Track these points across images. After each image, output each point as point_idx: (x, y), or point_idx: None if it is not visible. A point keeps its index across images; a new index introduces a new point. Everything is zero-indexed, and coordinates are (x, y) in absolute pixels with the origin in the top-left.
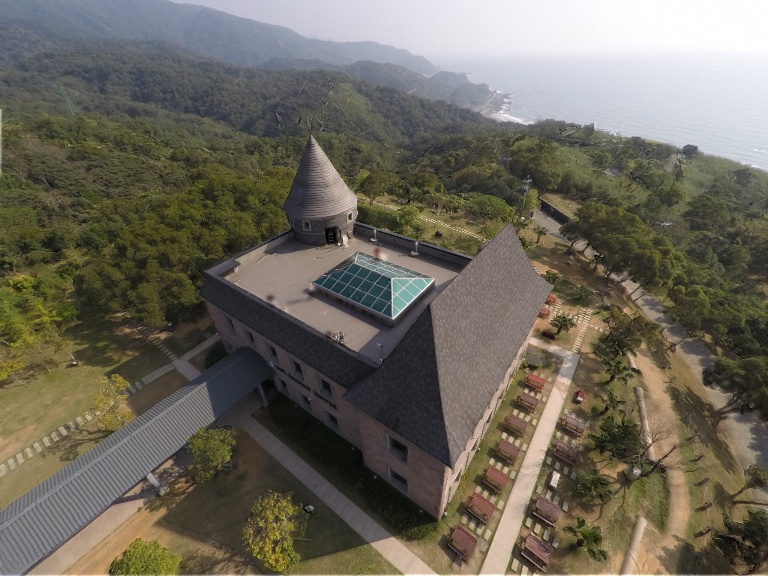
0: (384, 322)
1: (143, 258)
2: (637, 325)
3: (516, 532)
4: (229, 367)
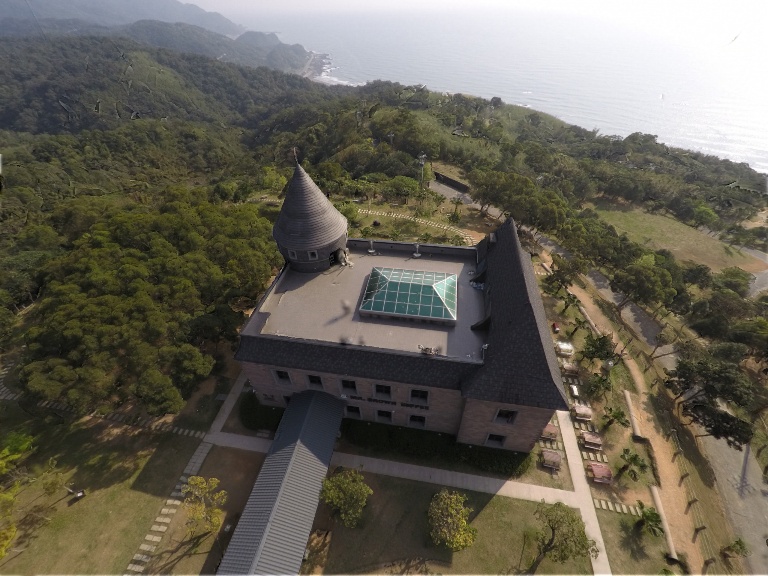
0: (446, 324)
1: (120, 343)
2: (575, 265)
3: (574, 435)
4: (308, 416)
